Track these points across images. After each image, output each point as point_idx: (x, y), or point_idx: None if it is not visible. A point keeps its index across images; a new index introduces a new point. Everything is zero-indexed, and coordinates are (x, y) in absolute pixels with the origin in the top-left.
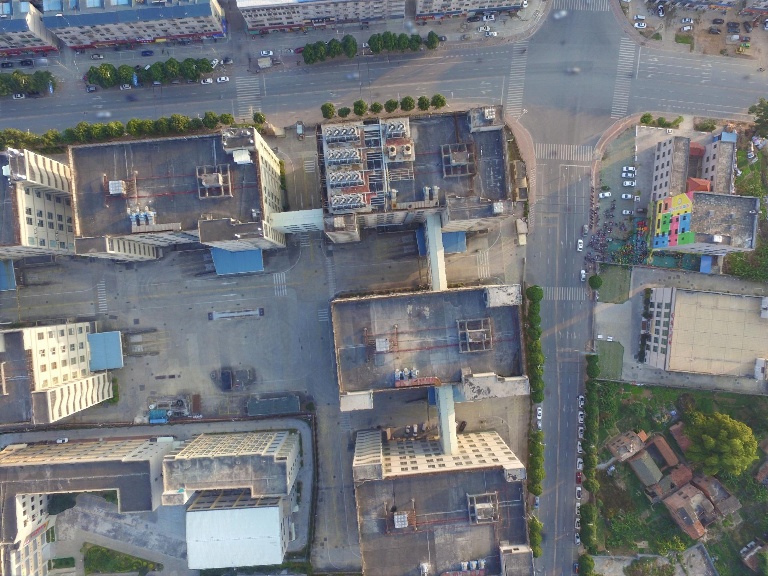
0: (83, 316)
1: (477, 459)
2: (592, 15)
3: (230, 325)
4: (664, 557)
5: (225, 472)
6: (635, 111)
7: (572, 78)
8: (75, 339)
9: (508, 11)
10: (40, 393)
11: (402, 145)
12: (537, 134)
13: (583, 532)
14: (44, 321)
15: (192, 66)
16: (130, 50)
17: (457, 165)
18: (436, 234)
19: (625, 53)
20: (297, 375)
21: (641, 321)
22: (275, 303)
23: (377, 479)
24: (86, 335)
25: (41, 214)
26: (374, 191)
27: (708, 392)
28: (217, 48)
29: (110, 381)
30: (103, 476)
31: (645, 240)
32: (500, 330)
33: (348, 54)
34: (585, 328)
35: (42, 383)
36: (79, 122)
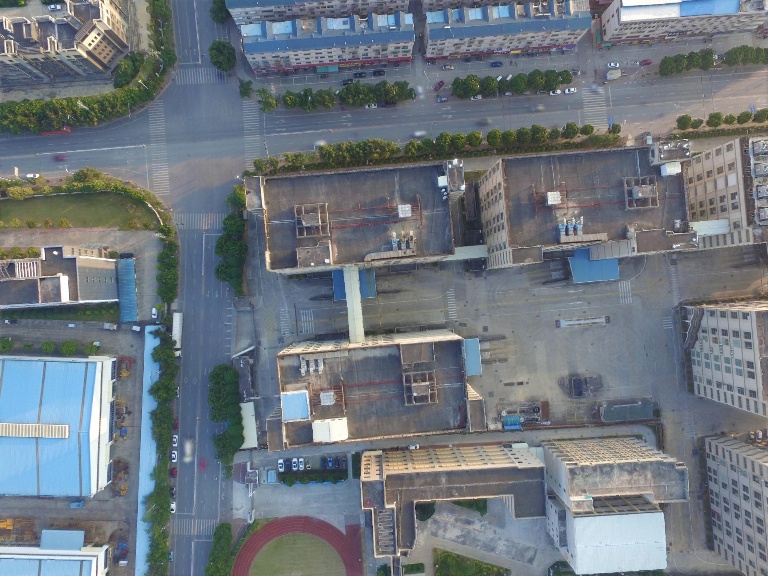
0: (433, 323)
1: None
2: None
3: (577, 332)
4: None
5: (625, 478)
6: None
7: None
8: None
9: None
10: (476, 401)
11: None
12: None
13: None
14: (403, 328)
15: (558, 78)
16: (479, 61)
17: None
18: None
19: None
20: (642, 382)
21: None
22: (620, 311)
23: None
24: None
25: None
26: None
27: None
28: (564, 60)
29: None
30: (498, 482)
31: None
32: None
33: (706, 67)
34: None
35: None
36: None
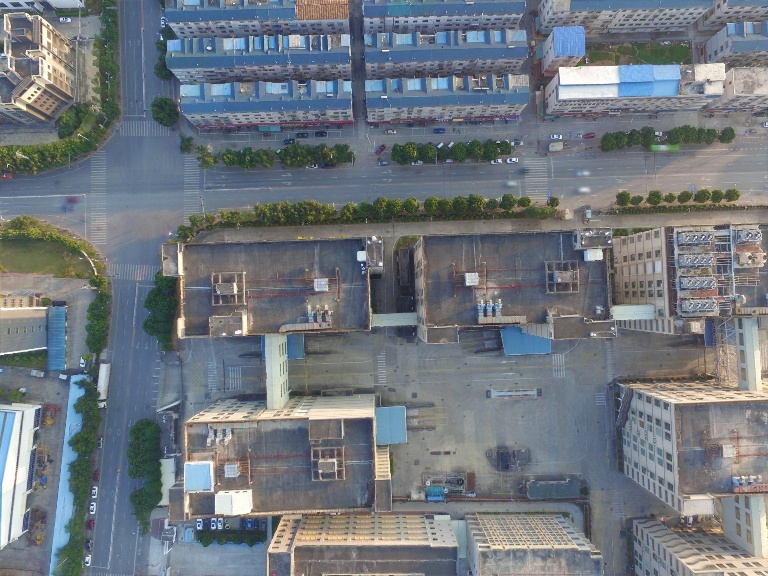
0: (362, 387)
1: None
2: None
3: (507, 404)
4: None
5: (538, 564)
6: None
7: None
8: None
9: None
10: (383, 481)
11: (751, 251)
12: None
13: None
14: (329, 392)
15: (496, 149)
16: (422, 127)
17: None
18: (754, 334)
19: None
20: (572, 458)
21: None
22: (553, 384)
23: None
24: None
25: None
26: (722, 296)
27: None
28: (507, 129)
29: None
30: (409, 560)
31: None
32: None
33: (647, 145)
34: None
35: None
36: (370, 195)
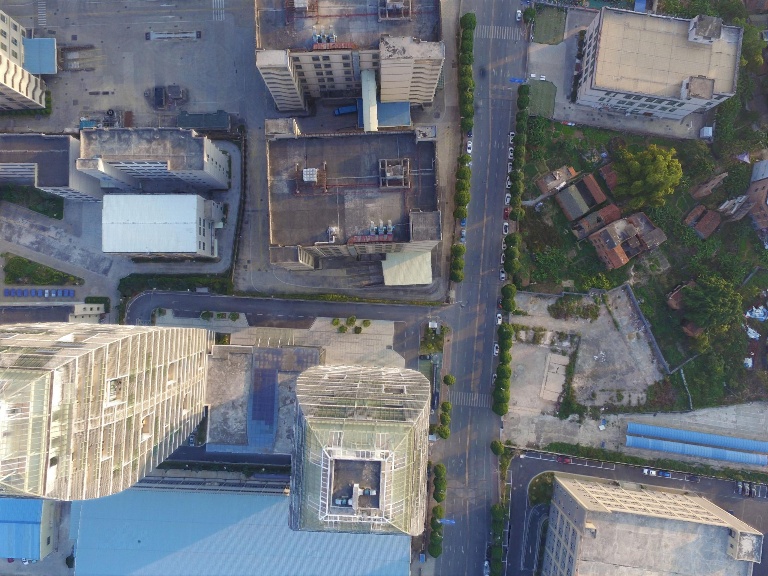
0: None
1: None
2: None
3: (167, 46)
4: (589, 297)
5: (143, 146)
6: None
7: None
8: (8, 30)
9: None
10: None
11: None
12: None
13: (506, 258)
14: None
15: None
16: None
17: None
18: None
19: None
20: (230, 98)
21: (575, 63)
22: (213, 27)
23: (288, 134)
24: (21, 37)
25: None
26: None
27: (640, 138)
28: None
29: (43, 91)
30: (22, 150)
31: None
32: (420, 2)
33: None
34: (519, 67)
35: None
36: None
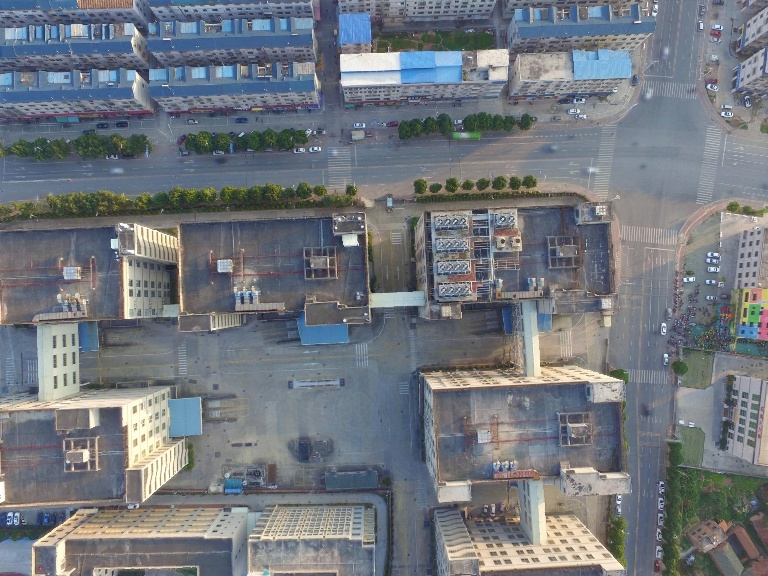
0: (162, 379)
1: (570, 554)
2: (680, 102)
3: (310, 394)
4: None
5: (310, 555)
6: (720, 198)
7: (659, 163)
8: (159, 407)
9: (599, 95)
10: (134, 471)
11: (510, 235)
12: (623, 216)
13: None
14: (124, 384)
15: (289, 138)
16: (225, 116)
17: (563, 257)
18: (532, 319)
19: (711, 140)
20: (375, 448)
21: (723, 408)
22: (356, 374)
23: (473, 574)
24: (167, 401)
25: (139, 284)
26: (480, 280)
27: None
28: (310, 118)
29: (187, 447)
30: (184, 552)
31: (728, 326)
32: (600, 424)
33: (443, 132)
34: (666, 412)
35: (134, 458)
36: (170, 185)
